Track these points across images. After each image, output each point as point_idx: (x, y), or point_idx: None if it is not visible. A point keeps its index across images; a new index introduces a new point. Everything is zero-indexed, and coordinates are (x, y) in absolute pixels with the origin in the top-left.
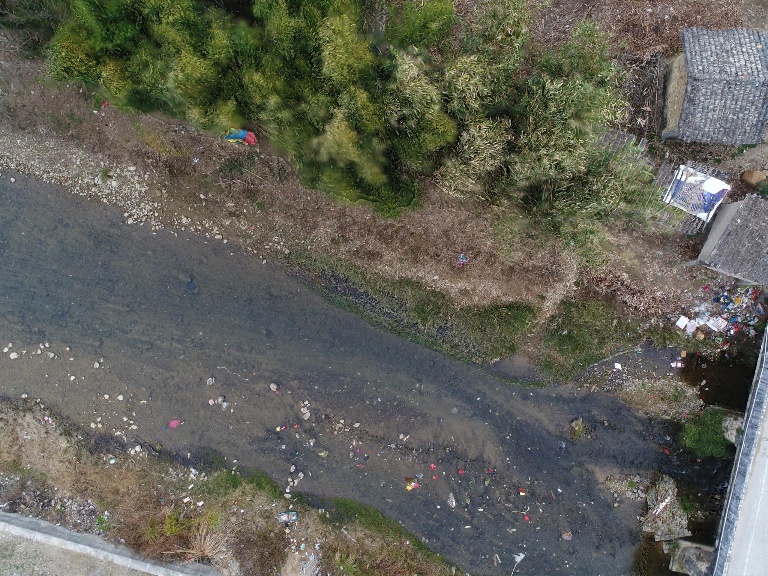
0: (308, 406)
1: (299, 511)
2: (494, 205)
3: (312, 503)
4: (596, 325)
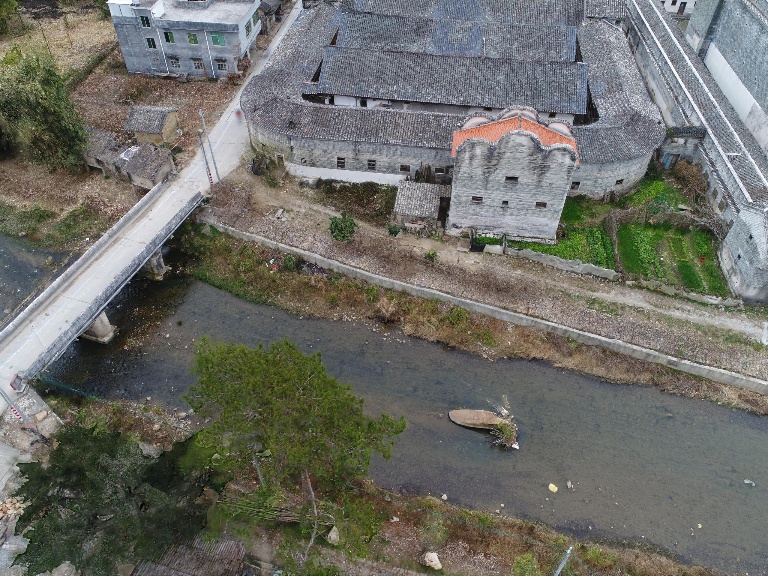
0: None
1: None
2: (11, 117)
3: None
4: None
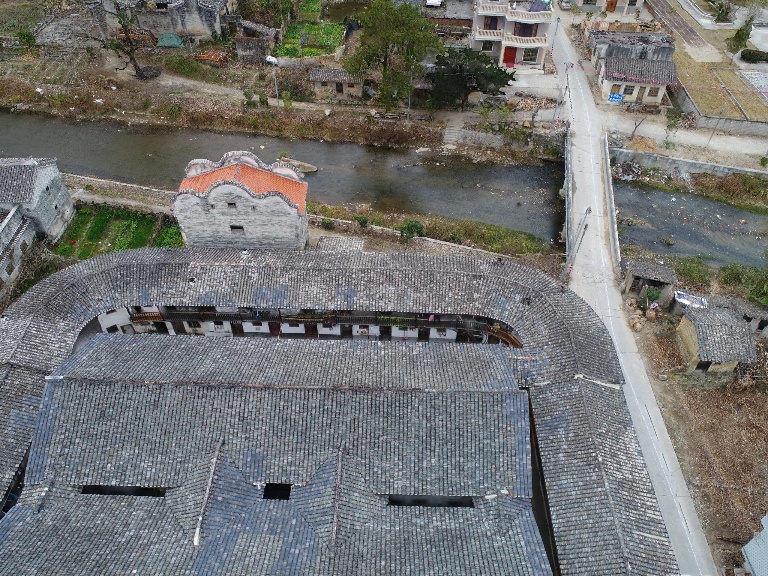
0: None
1: None
2: None
3: None
4: None
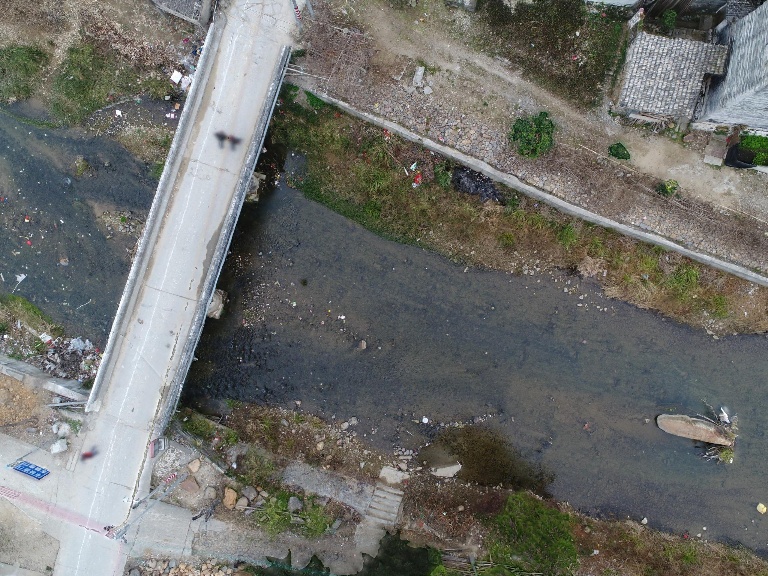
0: None
1: None
2: None
3: None
4: (102, 75)
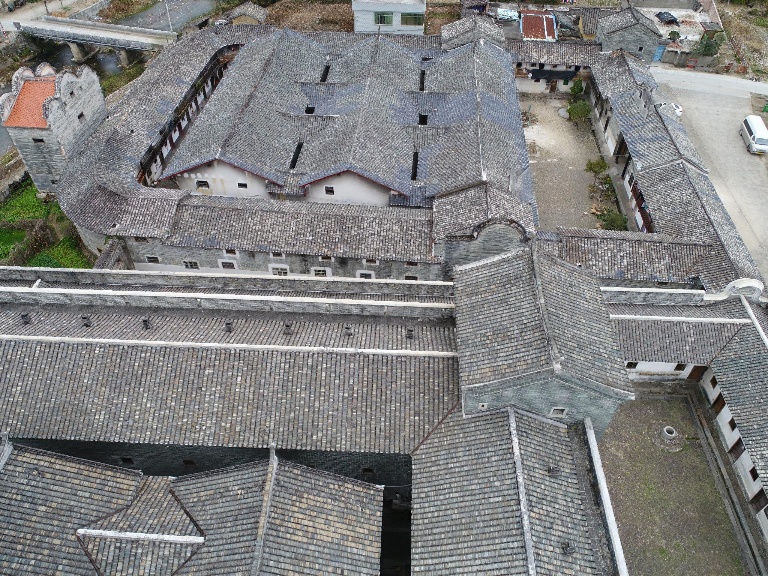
0: (186, 4)
1: (153, 1)
2: None
3: (154, 3)
4: None
